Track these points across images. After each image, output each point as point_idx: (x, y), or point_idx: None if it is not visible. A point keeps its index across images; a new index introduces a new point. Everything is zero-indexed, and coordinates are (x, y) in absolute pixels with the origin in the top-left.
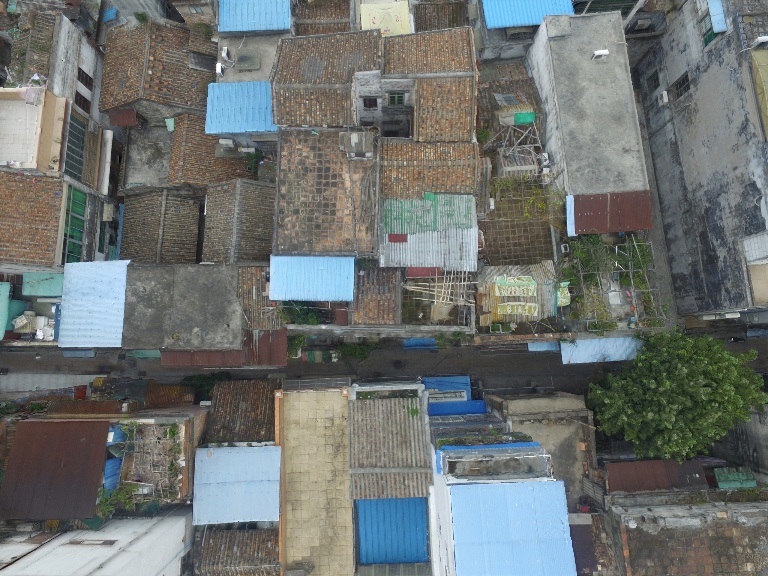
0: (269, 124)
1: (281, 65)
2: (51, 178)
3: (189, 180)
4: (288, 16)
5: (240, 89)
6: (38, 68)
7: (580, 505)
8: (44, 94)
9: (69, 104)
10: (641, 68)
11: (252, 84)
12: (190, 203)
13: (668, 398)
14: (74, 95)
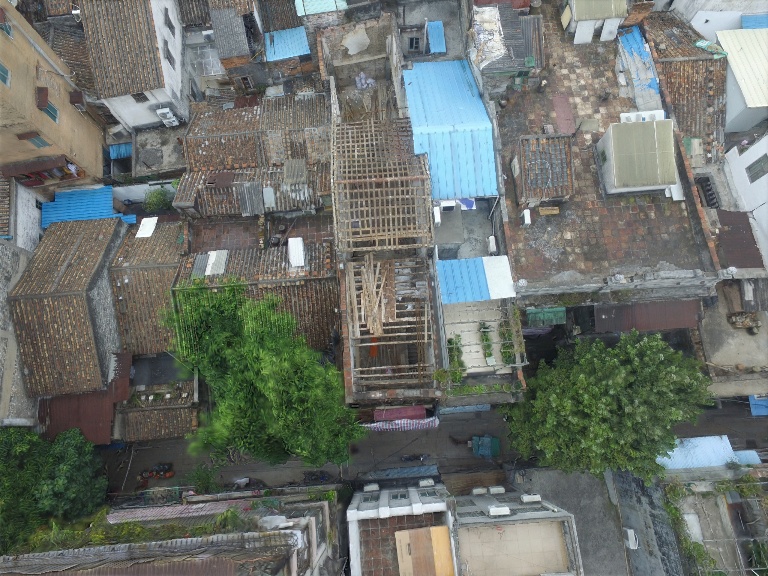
0: None
1: None
2: None
3: None
4: None
5: None
6: None
7: None
8: None
9: None
10: None
11: None
12: None
13: (661, 399)
14: None
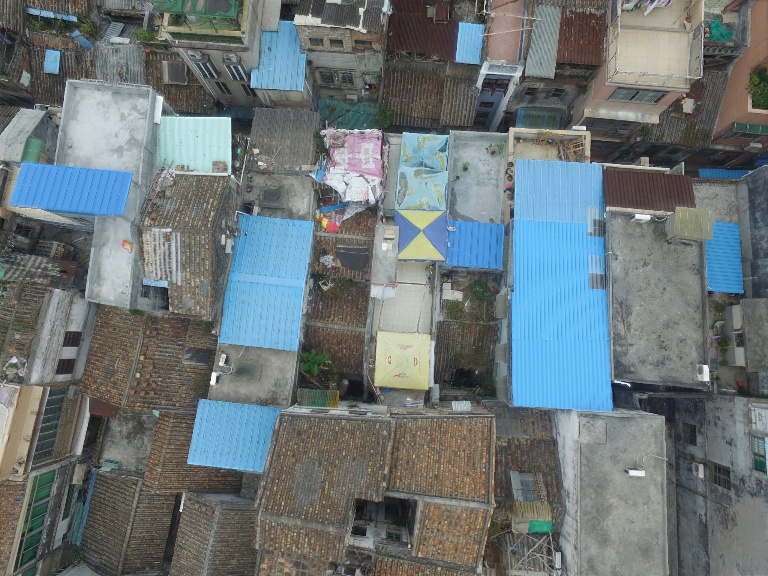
0: (258, 463)
1: (273, 469)
2: (14, 482)
3: (165, 490)
4: (296, 337)
5: (233, 412)
6: (18, 349)
7: None
8: (18, 395)
9: (46, 391)
10: (678, 403)
11: (247, 407)
12: (166, 493)
13: None
14: (56, 367)
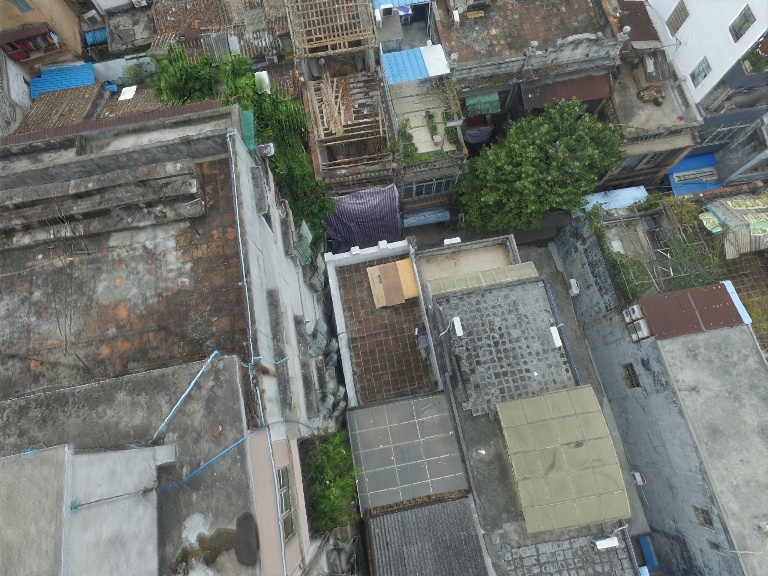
0: None
1: None
2: None
3: None
4: None
5: None
6: None
7: None
8: None
9: None
10: None
11: None
12: None
13: (580, 144)
14: None
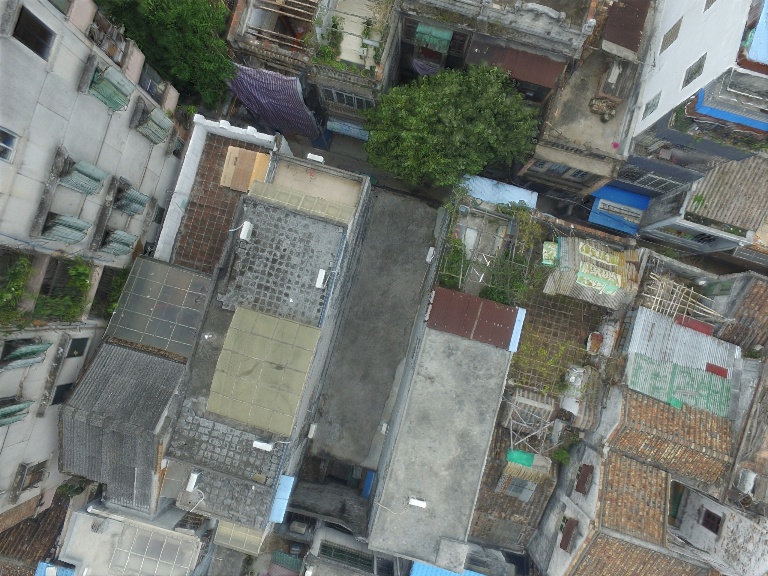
0: None
1: None
2: None
3: None
4: None
5: None
6: None
7: (580, 64)
8: None
9: None
10: None
11: None
12: None
13: (485, 122)
14: None
